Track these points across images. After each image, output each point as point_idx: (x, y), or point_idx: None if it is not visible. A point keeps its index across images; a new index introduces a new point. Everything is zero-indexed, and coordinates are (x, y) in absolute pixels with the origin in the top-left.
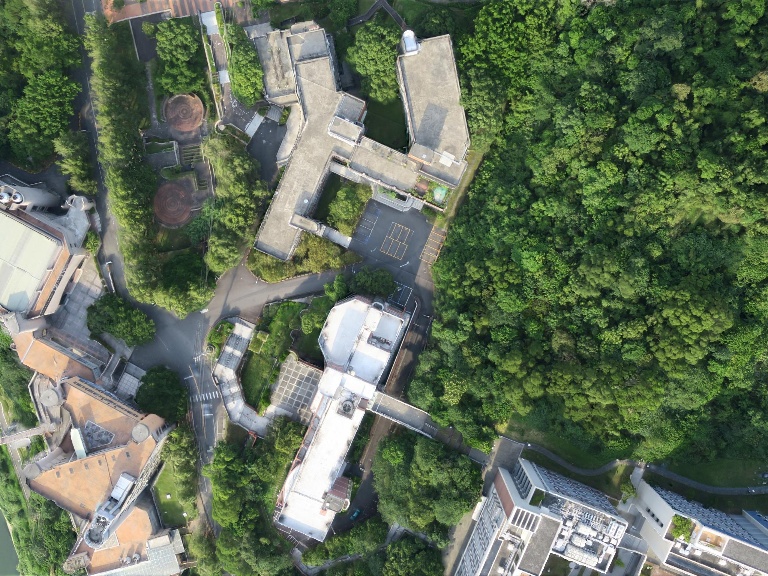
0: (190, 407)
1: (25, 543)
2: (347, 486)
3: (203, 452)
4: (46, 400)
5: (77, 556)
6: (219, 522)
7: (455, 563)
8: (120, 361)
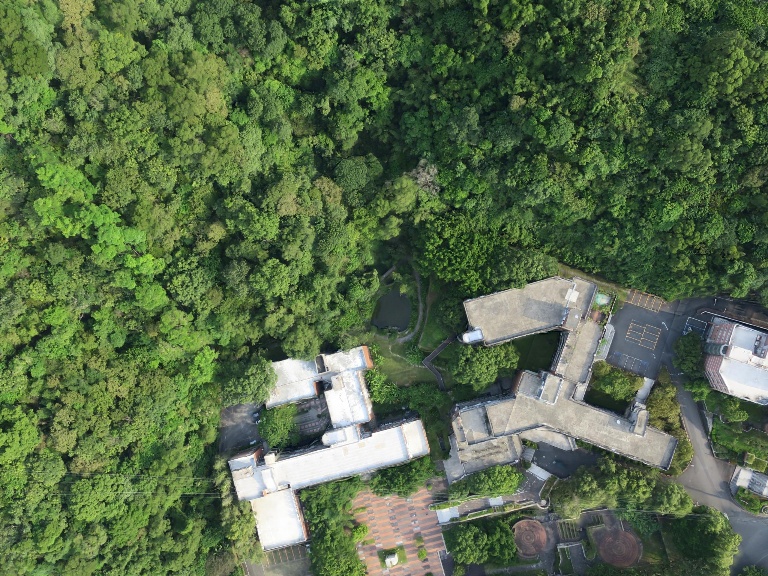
0: None
1: None
2: None
3: None
4: None
5: None
6: None
7: None
8: None
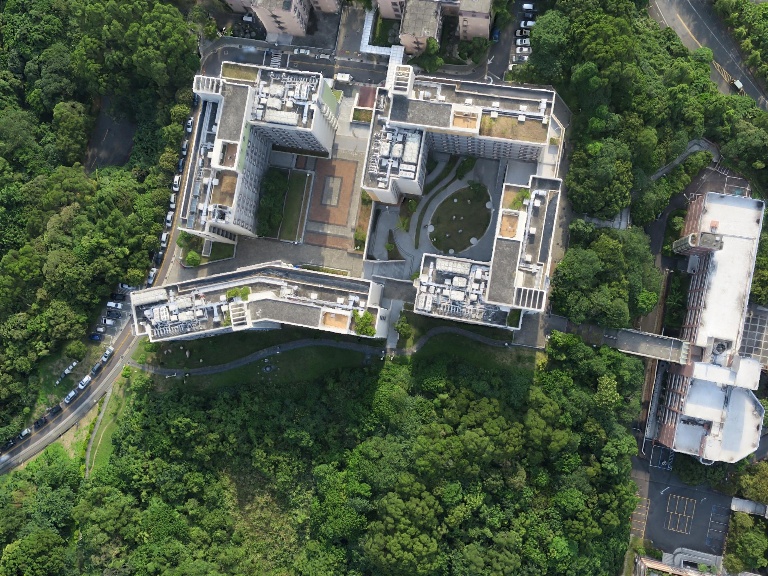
0: None
1: None
2: None
3: None
4: None
5: None
6: None
7: None
8: None
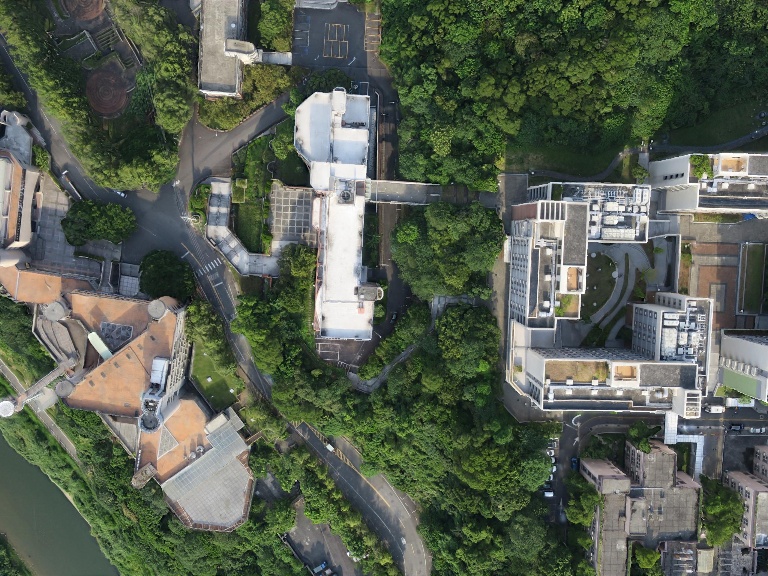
0: (197, 283)
1: (89, 503)
2: (375, 284)
3: (226, 322)
4: (52, 314)
5: (142, 469)
6: (266, 370)
7: (505, 315)
8: (112, 266)
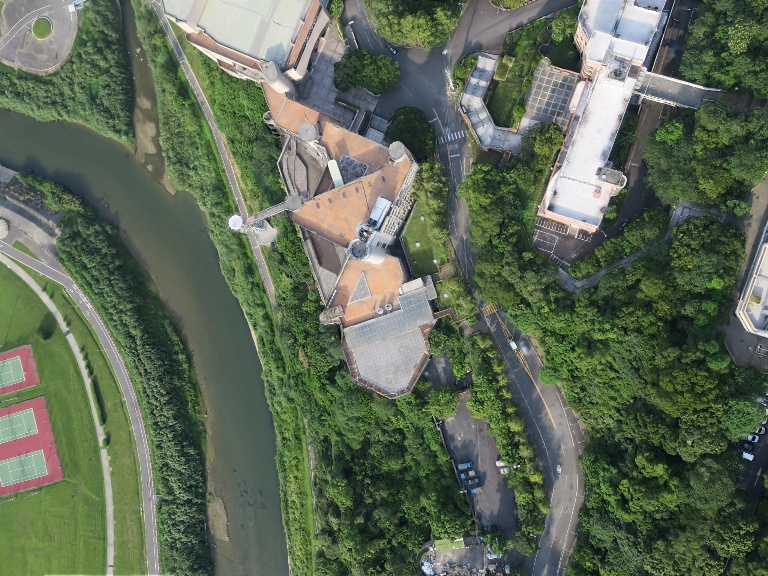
0: (436, 149)
1: (270, 345)
2: None
3: (451, 193)
4: (305, 134)
5: None
6: (479, 238)
7: (754, 243)
8: (365, 116)
